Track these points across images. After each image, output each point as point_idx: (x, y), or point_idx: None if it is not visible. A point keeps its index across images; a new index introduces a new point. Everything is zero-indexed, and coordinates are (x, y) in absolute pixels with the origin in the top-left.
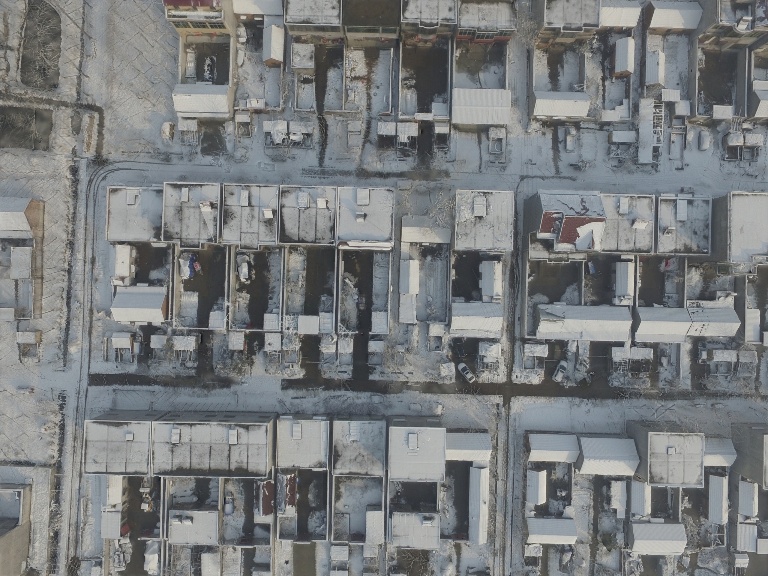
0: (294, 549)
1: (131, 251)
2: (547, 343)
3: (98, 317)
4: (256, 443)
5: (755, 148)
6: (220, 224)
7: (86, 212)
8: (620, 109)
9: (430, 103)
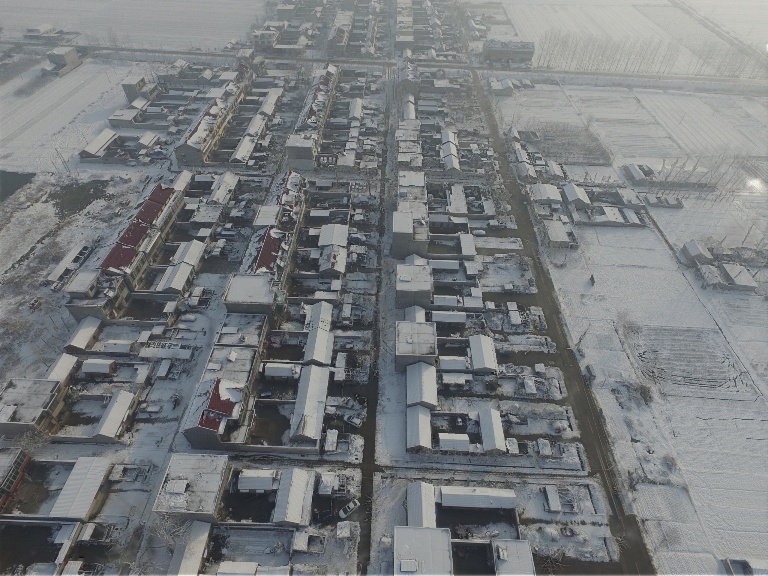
0: None
1: None
2: None
3: None
4: None
5: (204, 291)
6: None
7: None
8: (140, 370)
9: (54, 547)
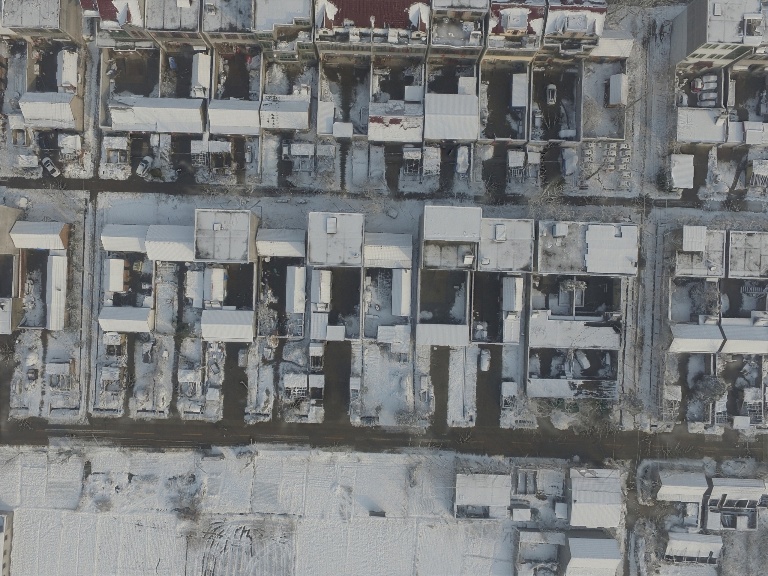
0: None
1: None
2: (134, 140)
3: None
4: None
5: None
6: None
7: None
8: None
9: None
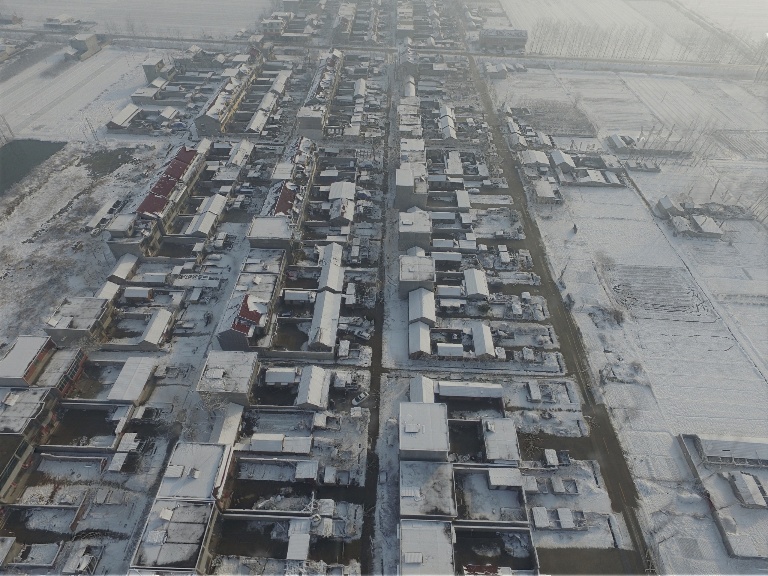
0: (552, 575)
1: None
2: None
3: None
4: None
5: (228, 236)
6: None
7: None
8: (175, 296)
9: (111, 425)
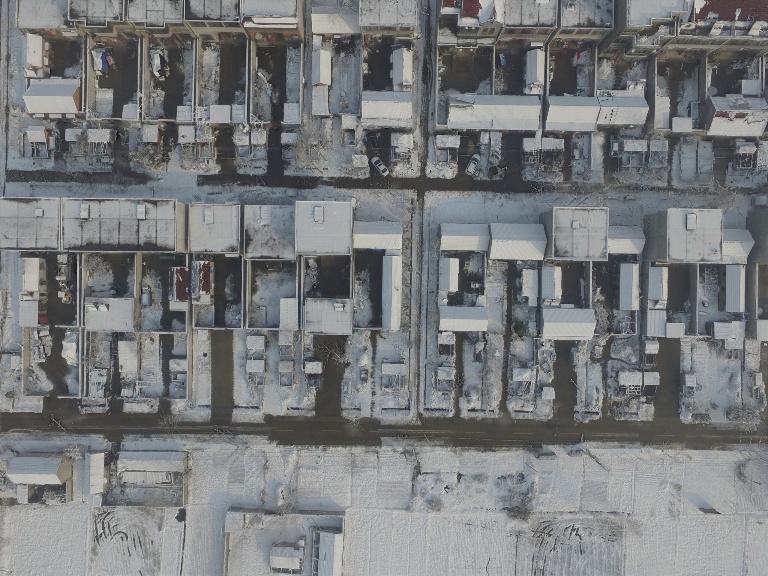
0: (212, 342)
1: (44, 43)
2: (461, 138)
3: (14, 114)
4: (164, 218)
5: None
6: (126, 2)
7: (0, 9)
8: None
9: None
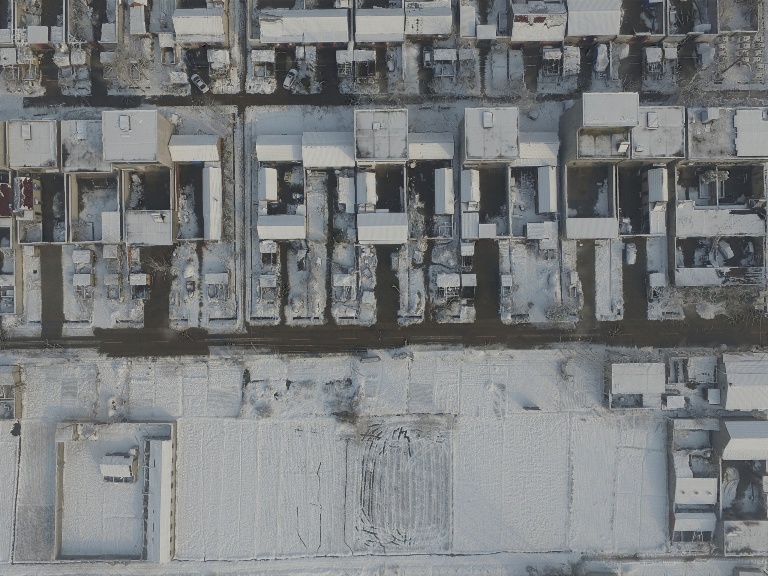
0: (41, 259)
1: None
2: (278, 54)
3: None
4: None
5: None
6: None
7: None
8: None
9: None
